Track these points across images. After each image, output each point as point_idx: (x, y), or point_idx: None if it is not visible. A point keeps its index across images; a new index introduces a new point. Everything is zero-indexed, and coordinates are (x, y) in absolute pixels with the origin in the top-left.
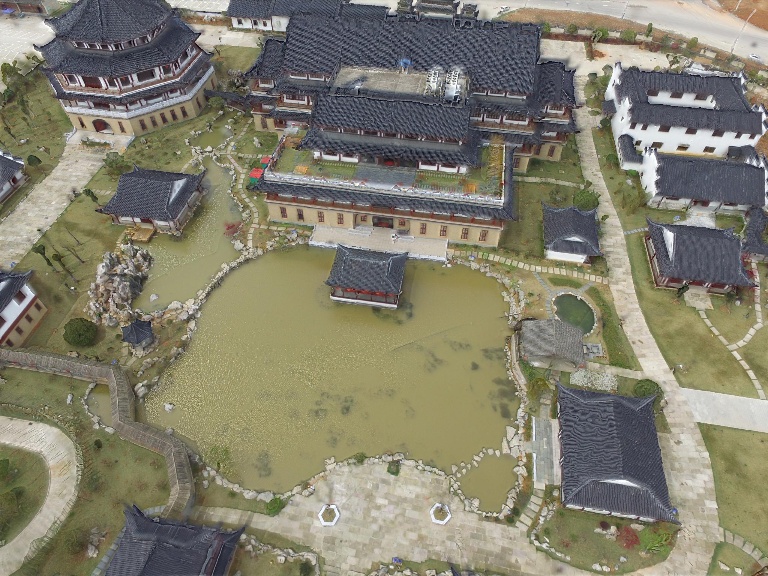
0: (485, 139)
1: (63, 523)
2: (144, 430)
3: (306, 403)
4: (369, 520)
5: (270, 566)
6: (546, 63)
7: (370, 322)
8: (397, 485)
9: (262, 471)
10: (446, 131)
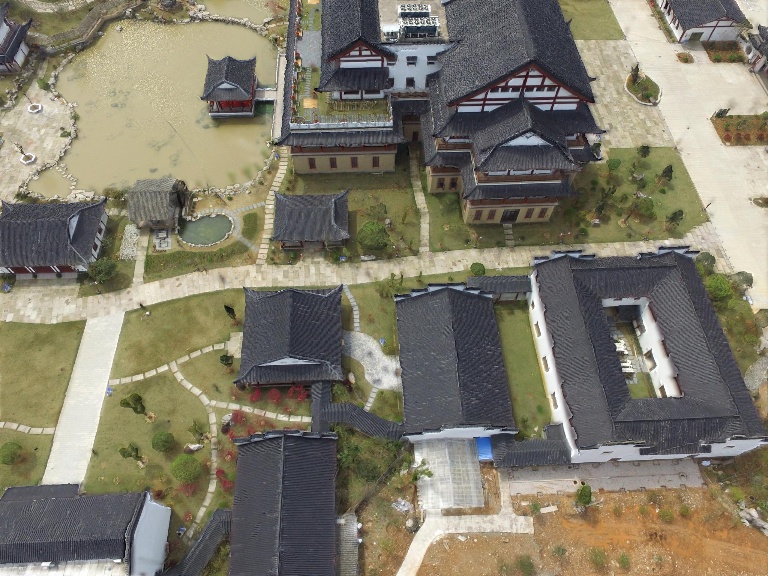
0: (421, 118)
1: (44, 12)
2: (89, 16)
3: (120, 86)
4: (30, 127)
5: (6, 88)
6: (529, 110)
7: (200, 108)
8: (53, 137)
9: (71, 77)
10: (337, 41)
